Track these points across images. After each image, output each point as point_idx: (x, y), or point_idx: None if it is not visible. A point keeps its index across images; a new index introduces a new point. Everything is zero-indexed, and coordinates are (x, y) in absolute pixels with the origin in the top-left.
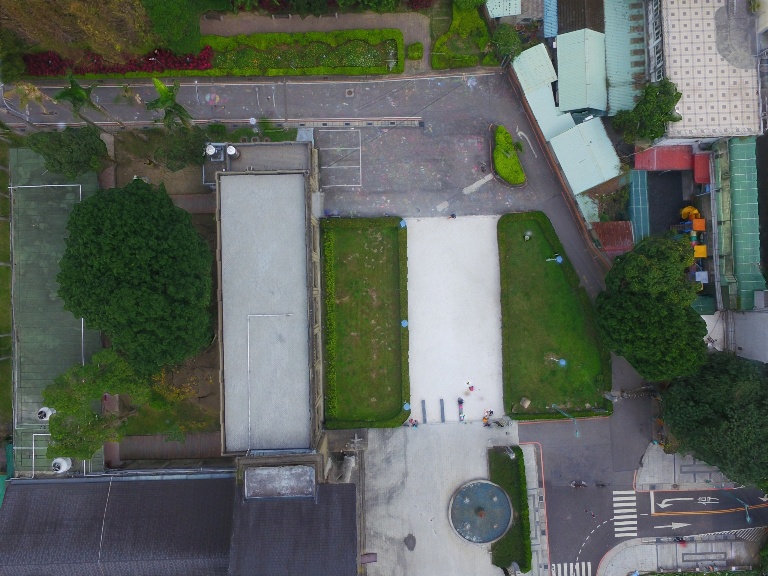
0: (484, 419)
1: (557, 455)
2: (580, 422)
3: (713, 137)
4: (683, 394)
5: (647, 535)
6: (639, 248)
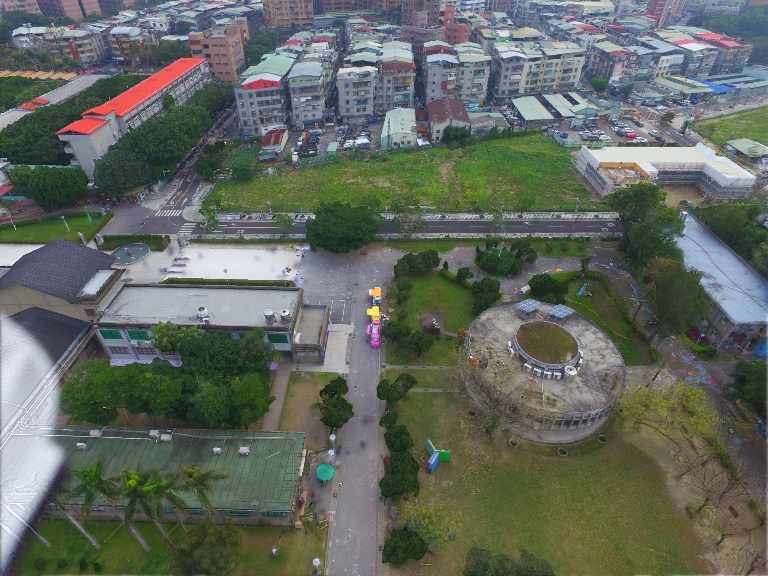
0: None
1: (122, 230)
2: (111, 223)
3: None
4: (100, 182)
5: (184, 208)
6: (10, 180)
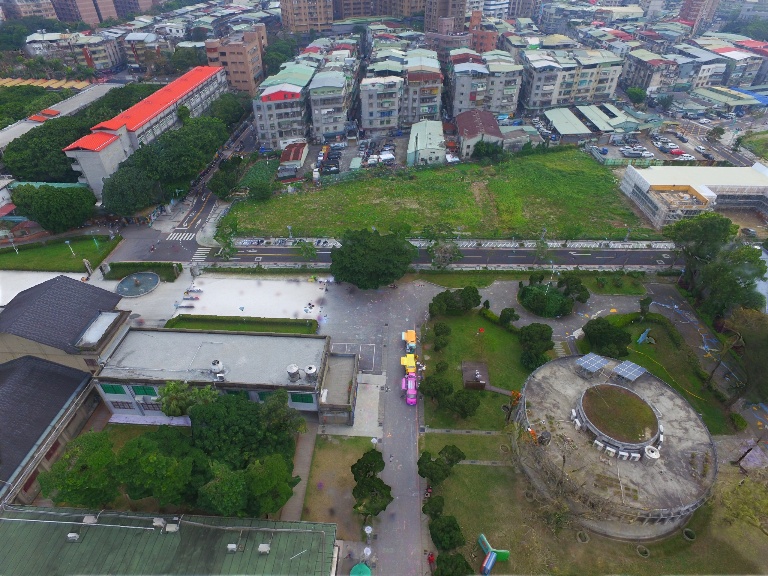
0: (83, 280)
1: (131, 256)
2: (119, 248)
3: (0, 190)
4: (109, 202)
5: (197, 231)
6: None
